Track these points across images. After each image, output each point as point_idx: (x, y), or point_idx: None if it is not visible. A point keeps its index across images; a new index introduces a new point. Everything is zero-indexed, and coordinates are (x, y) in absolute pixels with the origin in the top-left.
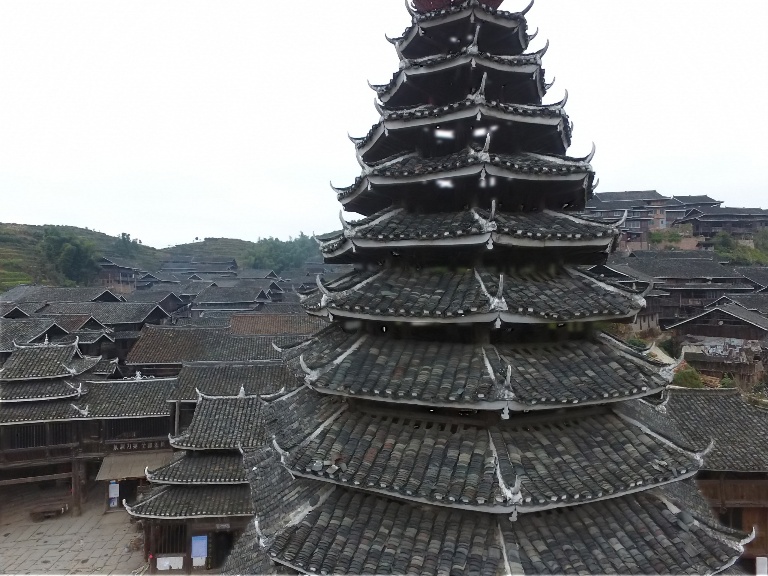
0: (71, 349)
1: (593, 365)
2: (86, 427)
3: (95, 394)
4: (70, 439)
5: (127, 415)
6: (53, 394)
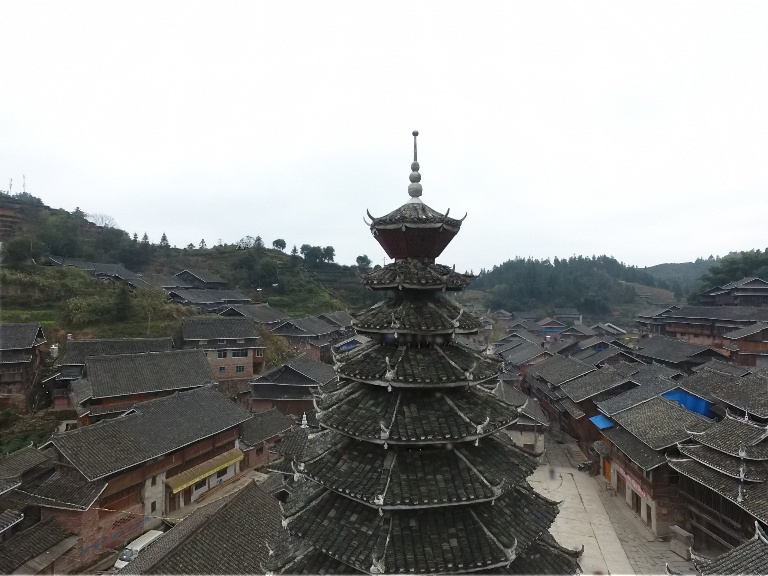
0: (762, 432)
1: (296, 545)
2: (748, 514)
3: (767, 486)
4: (737, 518)
5: (766, 522)
6: (724, 469)
